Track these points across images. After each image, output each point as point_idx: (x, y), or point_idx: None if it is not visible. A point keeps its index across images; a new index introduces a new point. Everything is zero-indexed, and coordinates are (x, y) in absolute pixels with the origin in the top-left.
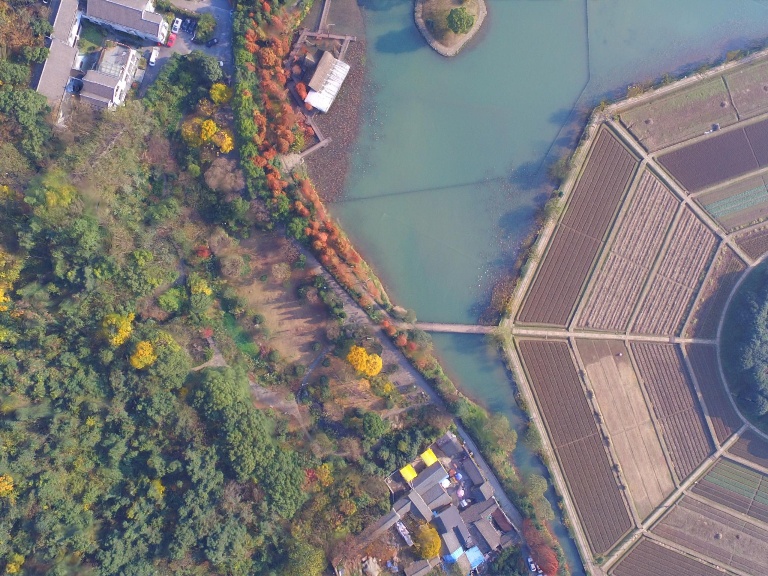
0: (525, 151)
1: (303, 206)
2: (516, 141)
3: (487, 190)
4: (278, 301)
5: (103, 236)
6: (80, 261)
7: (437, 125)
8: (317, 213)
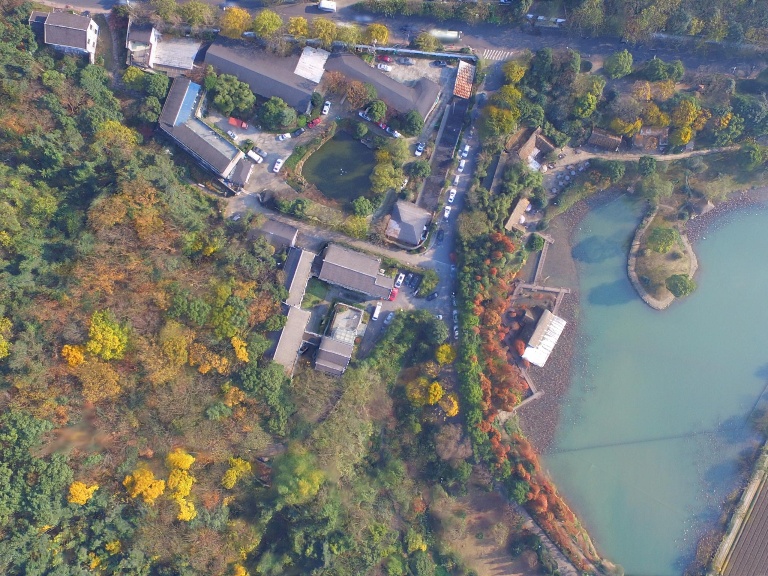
0: (732, 404)
1: (525, 470)
2: (723, 394)
3: (694, 444)
4: (490, 556)
5: (340, 511)
6: (316, 535)
7: (646, 377)
8: (537, 476)
